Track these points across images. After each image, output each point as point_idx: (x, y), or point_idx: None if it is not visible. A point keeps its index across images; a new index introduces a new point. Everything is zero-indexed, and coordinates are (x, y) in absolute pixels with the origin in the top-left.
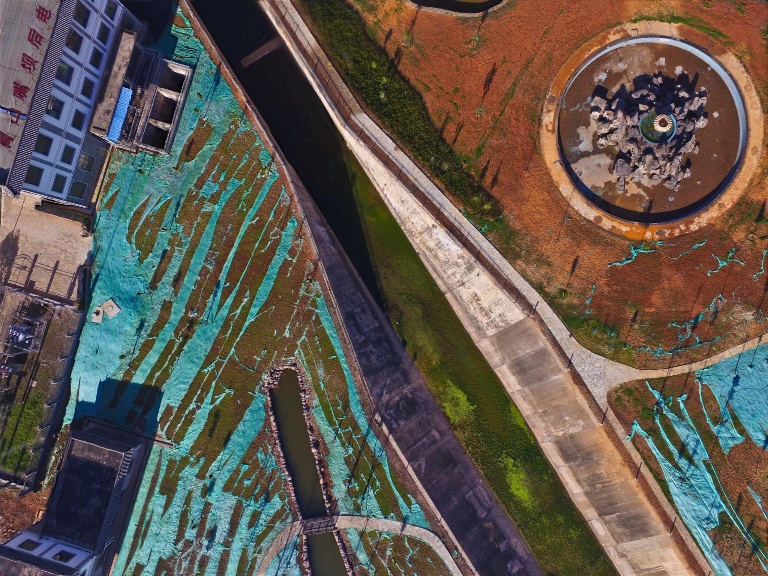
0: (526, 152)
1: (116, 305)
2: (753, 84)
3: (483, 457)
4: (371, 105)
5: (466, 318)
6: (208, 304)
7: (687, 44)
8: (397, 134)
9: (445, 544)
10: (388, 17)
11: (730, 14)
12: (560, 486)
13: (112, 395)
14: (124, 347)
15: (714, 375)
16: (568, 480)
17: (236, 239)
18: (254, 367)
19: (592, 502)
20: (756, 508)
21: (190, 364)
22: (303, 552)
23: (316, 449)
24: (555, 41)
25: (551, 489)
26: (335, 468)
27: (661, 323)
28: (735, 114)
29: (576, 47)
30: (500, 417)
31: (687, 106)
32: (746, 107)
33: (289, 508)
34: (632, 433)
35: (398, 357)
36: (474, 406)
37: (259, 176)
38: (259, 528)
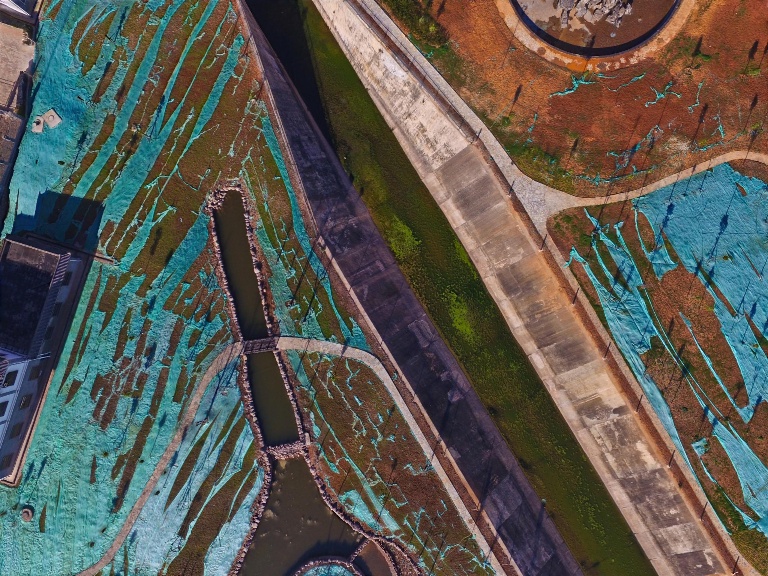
0: None
1: (57, 115)
2: None
3: (427, 292)
4: None
5: (413, 153)
6: (152, 120)
7: None
8: None
9: (385, 367)
10: None
11: None
12: (502, 321)
13: (52, 209)
14: (65, 159)
15: (649, 203)
16: (509, 314)
17: (181, 54)
18: (198, 186)
19: (532, 334)
20: (687, 333)
21: (132, 179)
22: (243, 373)
23: (258, 269)
24: None
25: (493, 324)
26: (277, 290)
27: (600, 152)
28: None
29: None
30: (444, 253)
31: None
32: None
33: (230, 329)
34: (570, 259)
35: (345, 190)
36: (419, 241)
37: None
38: (199, 347)
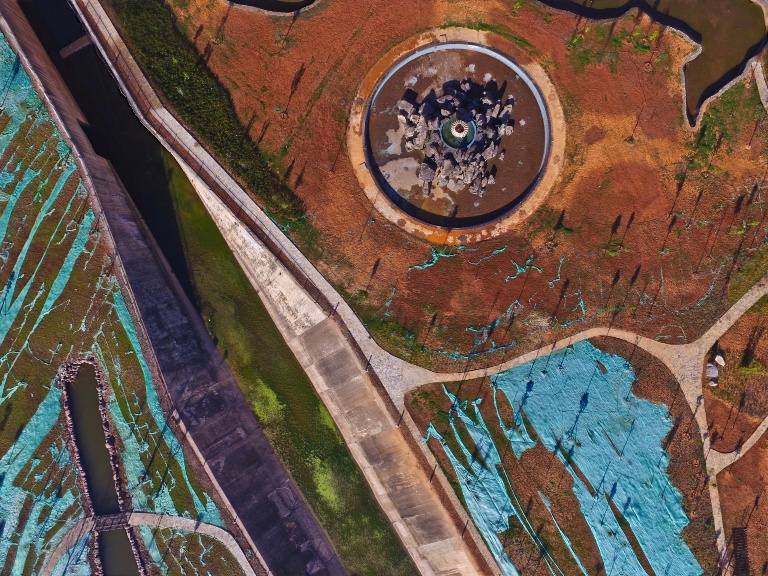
0: (332, 153)
1: None
2: (557, 94)
3: (291, 457)
4: (172, 100)
5: (277, 317)
6: (2, 295)
7: (494, 52)
8: (198, 130)
9: (239, 543)
10: (199, 13)
11: (536, 24)
12: (366, 487)
13: None
14: None
15: (509, 380)
16: (373, 481)
17: (31, 230)
18: (49, 360)
19: (395, 504)
20: (546, 512)
21: None
22: (94, 549)
23: (110, 445)
24: (364, 43)
25: (357, 490)
26: (130, 464)
27: (459, 327)
28: (541, 123)
29: (385, 50)
30: (309, 417)
31: (489, 113)
32: (549, 116)
33: (82, 504)
34: (427, 436)
35: (207, 354)
36: (283, 405)
37: (56, 167)
38: (49, 523)
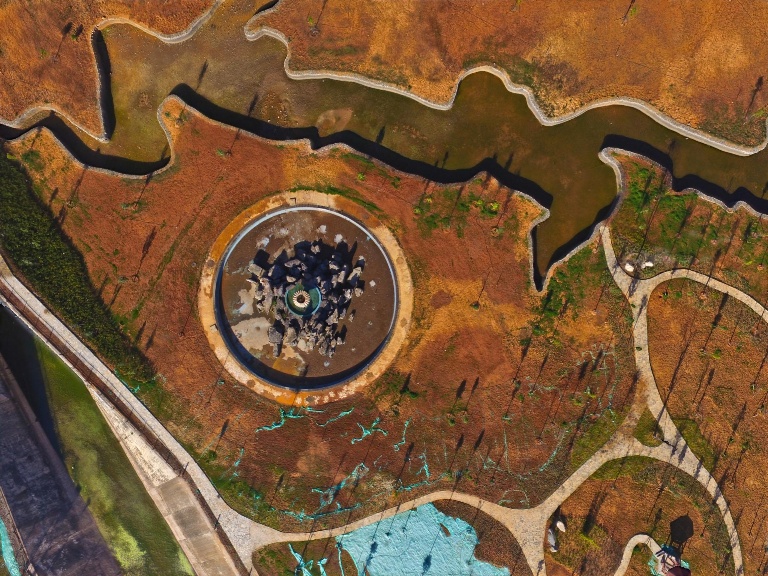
0: (183, 315)
1: None
2: (405, 257)
3: None
4: (23, 268)
5: (137, 467)
6: None
7: (343, 215)
8: (48, 297)
9: None
10: (55, 176)
11: (384, 188)
12: None
13: None
14: None
15: (353, 541)
16: None
17: None
18: None
19: None
20: None
21: None
22: None
23: None
24: (215, 207)
25: None
26: None
27: (305, 488)
28: (391, 284)
29: (236, 213)
30: (169, 564)
31: (335, 279)
32: (397, 279)
33: None
34: None
35: (68, 503)
36: (144, 552)
37: None
38: None
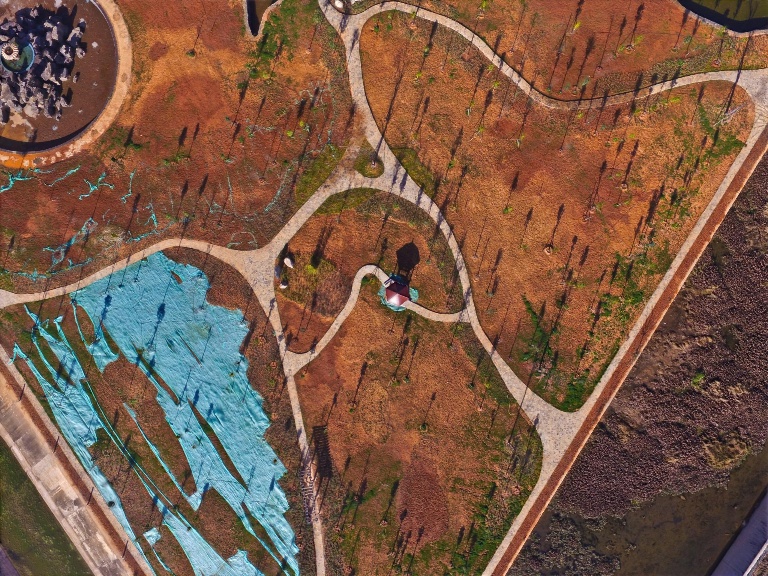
0: None
1: None
2: (121, 13)
3: None
4: None
5: None
6: None
7: None
8: None
9: None
10: None
11: None
12: None
13: None
14: None
15: (87, 296)
16: None
17: None
18: None
19: (5, 428)
20: (132, 424)
21: None
22: None
23: None
24: None
25: None
26: None
27: (36, 248)
28: (113, 44)
29: None
30: None
31: (49, 36)
32: (115, 36)
33: None
34: (13, 356)
35: None
36: None
37: None
38: None
